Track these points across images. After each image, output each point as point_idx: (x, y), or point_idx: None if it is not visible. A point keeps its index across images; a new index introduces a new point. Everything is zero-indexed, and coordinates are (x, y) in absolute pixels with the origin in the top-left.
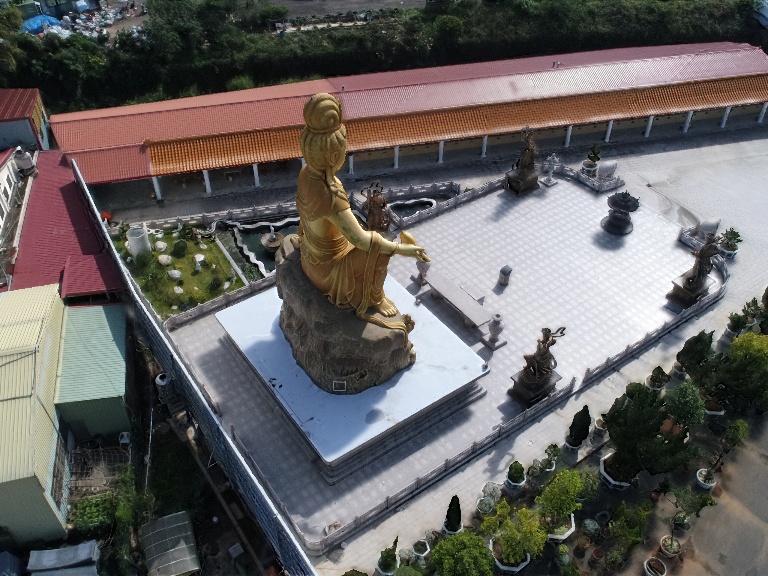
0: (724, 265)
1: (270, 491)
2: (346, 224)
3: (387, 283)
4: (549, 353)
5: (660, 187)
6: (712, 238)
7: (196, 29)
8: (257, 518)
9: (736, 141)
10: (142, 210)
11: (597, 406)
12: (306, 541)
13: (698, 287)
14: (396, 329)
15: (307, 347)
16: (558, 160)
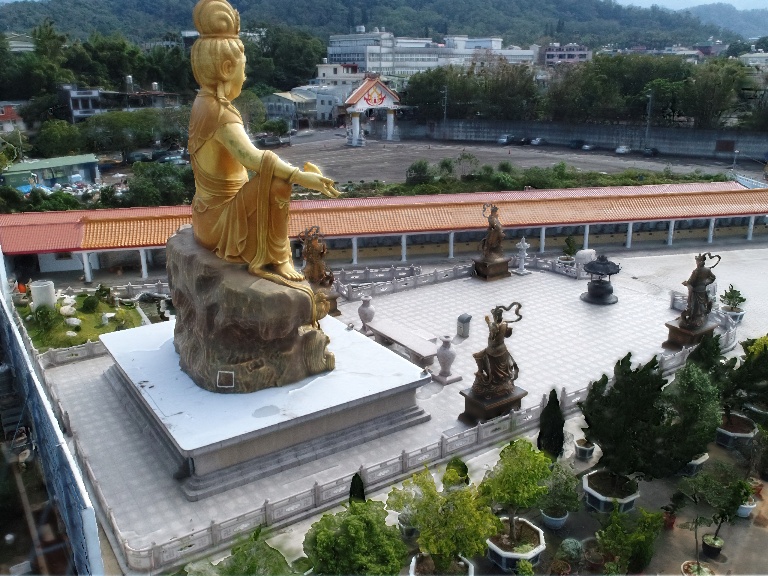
0: (728, 320)
1: (99, 500)
2: (234, 137)
3: None
4: (504, 346)
5: (647, 278)
6: None
7: (178, 187)
8: (66, 526)
9: (726, 250)
10: (65, 288)
11: (579, 434)
12: (127, 551)
13: (698, 325)
14: (298, 289)
15: (192, 338)
16: (529, 245)
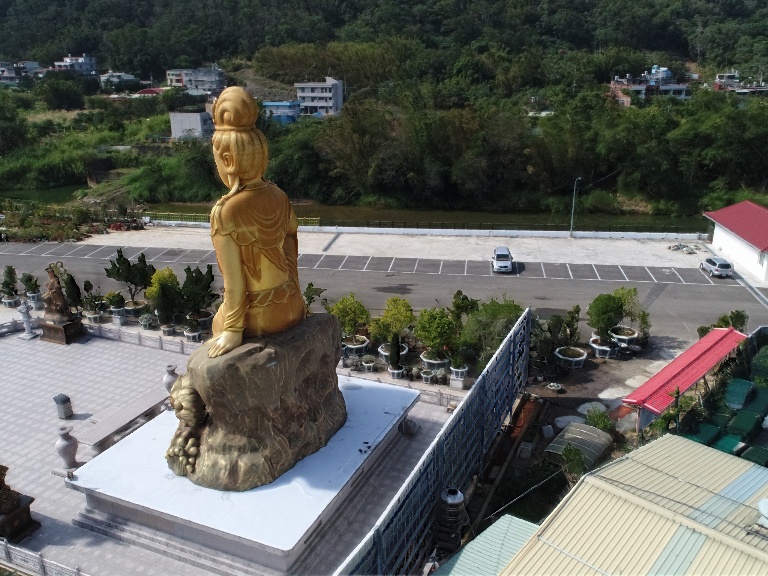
0: (19, 322)
1: None
2: None
3: (140, 438)
4: None
5: None
6: None
7: None
8: None
9: None
10: None
11: None
12: None
13: None
14: None
15: None
16: None
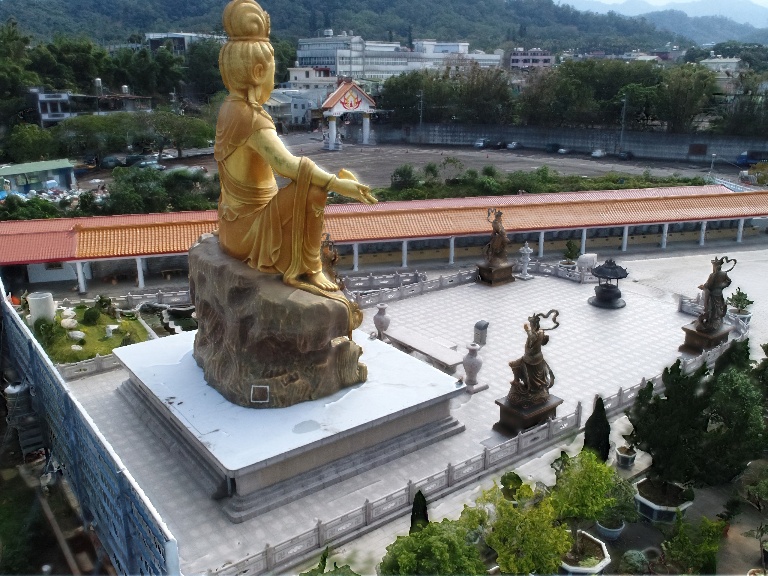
0: (739, 322)
1: None
2: (269, 143)
3: None
4: (541, 354)
5: (648, 282)
6: (719, 263)
7: (161, 193)
8: (110, 555)
9: (719, 252)
10: (59, 299)
11: (615, 441)
12: None
13: (715, 329)
14: (335, 300)
15: (221, 351)
16: (532, 250)
